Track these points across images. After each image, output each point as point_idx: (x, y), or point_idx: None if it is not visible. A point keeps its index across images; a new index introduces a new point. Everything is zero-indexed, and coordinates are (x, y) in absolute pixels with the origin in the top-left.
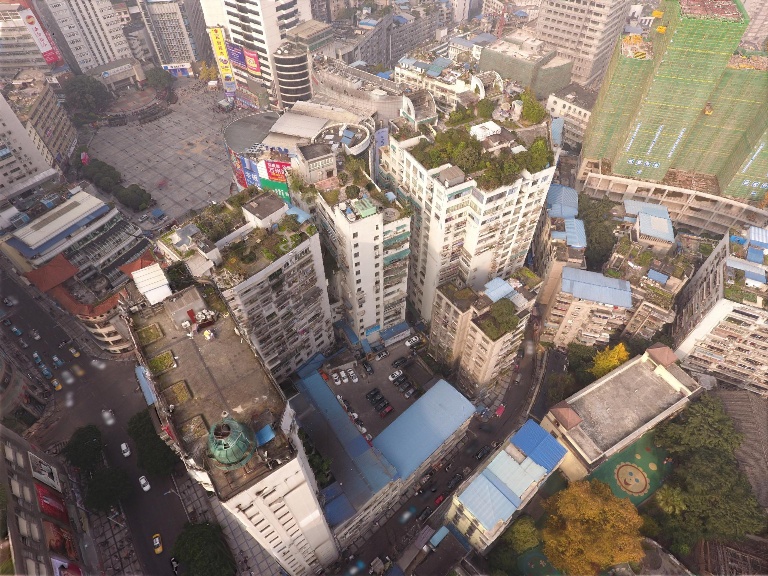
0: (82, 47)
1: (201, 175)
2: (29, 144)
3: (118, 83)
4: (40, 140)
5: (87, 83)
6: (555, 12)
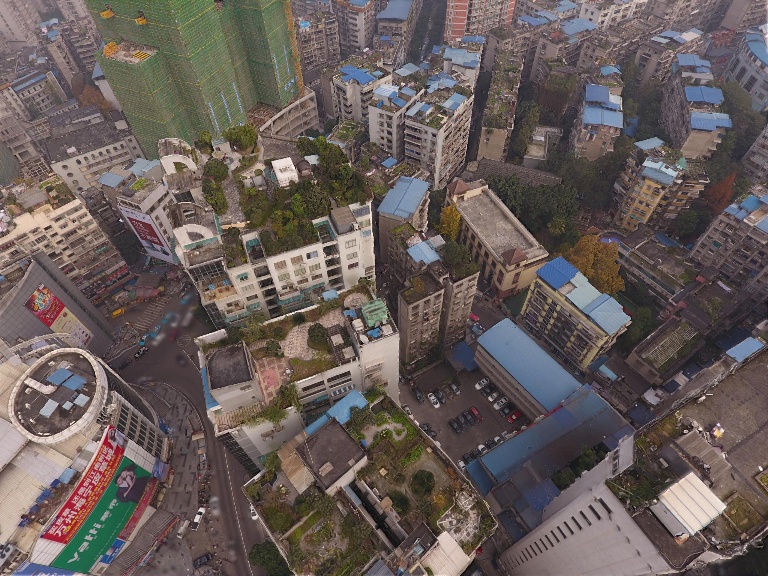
0: None
1: None
2: None
3: None
4: None
5: None
6: None
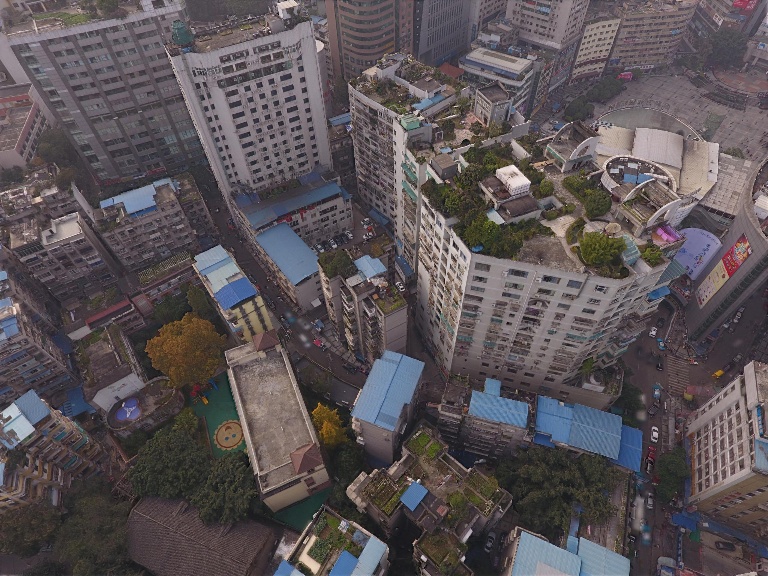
0: None
1: None
2: (564, 18)
3: (764, 62)
4: (613, 38)
5: (731, 39)
6: None
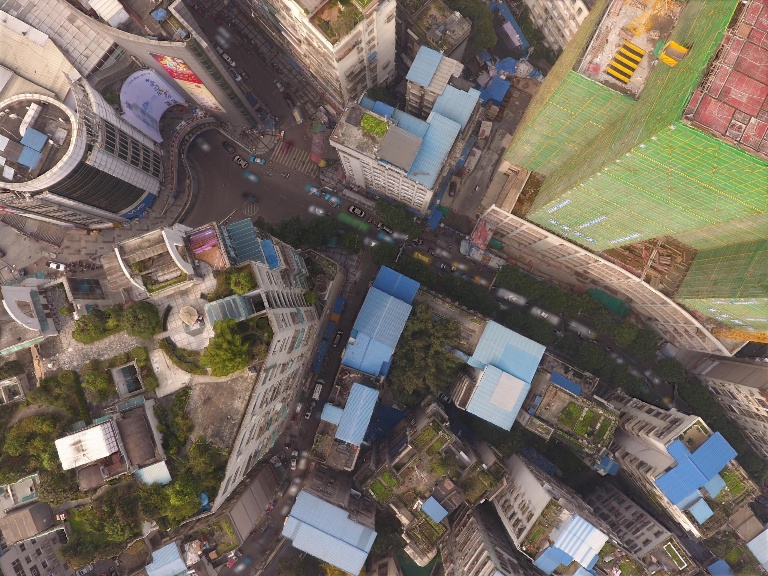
0: None
1: None
2: None
3: None
4: None
5: None
6: None
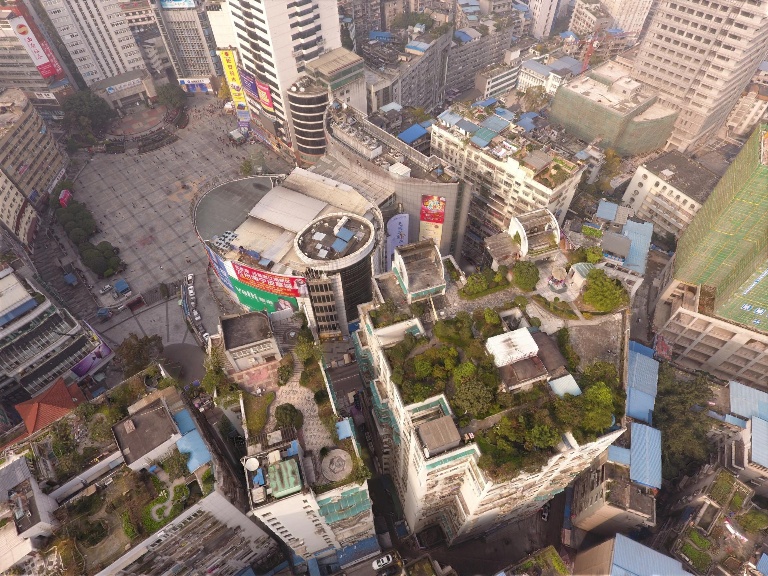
0: (87, 58)
1: (186, 233)
2: None
3: (126, 99)
4: (7, 180)
5: (86, 101)
6: (663, 48)
